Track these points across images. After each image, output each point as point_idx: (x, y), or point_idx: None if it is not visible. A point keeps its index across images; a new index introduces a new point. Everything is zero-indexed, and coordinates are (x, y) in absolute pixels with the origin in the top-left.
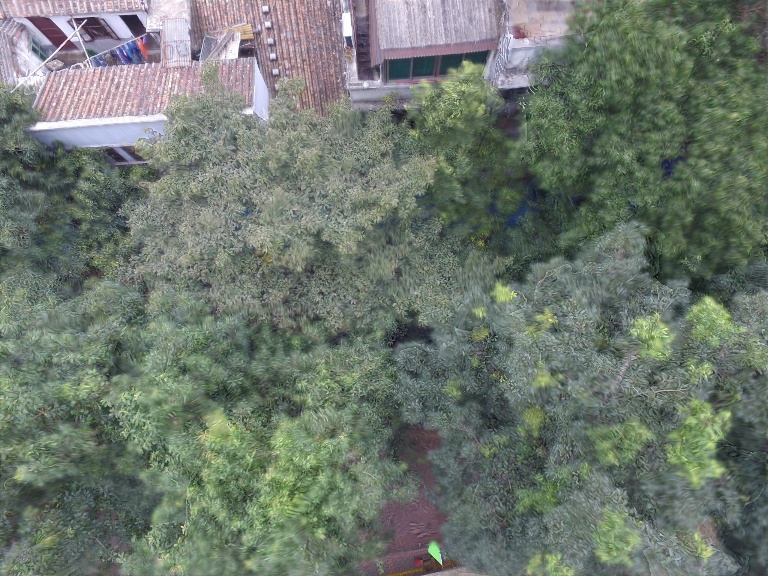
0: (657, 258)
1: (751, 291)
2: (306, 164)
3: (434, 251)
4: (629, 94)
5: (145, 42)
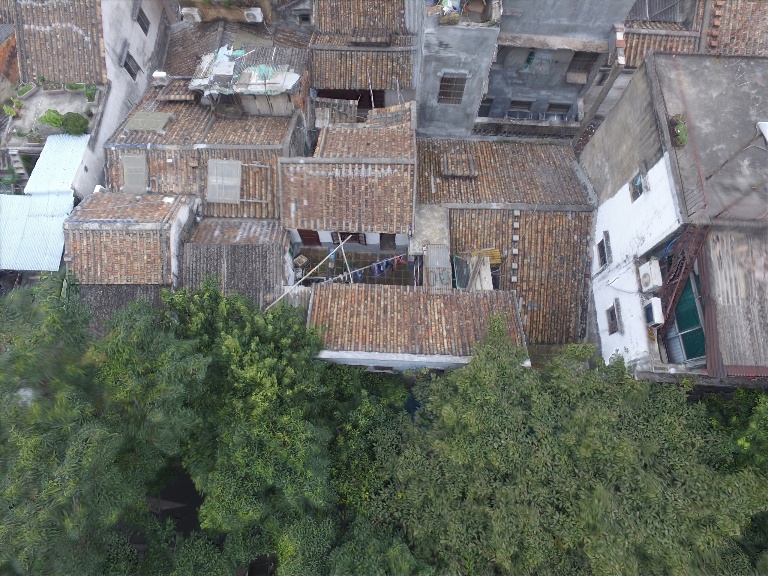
0: None
1: None
2: (624, 459)
3: None
4: None
5: None
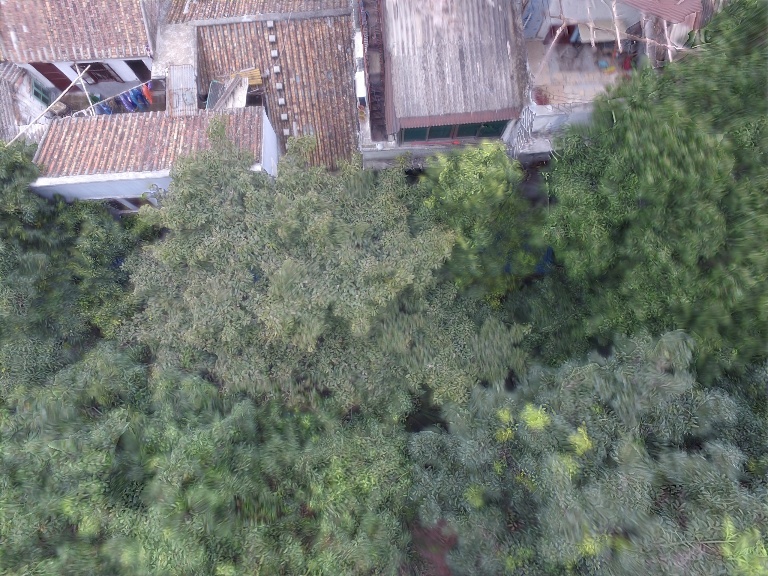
0: None
1: None
2: (317, 233)
3: (448, 315)
4: (665, 186)
5: (150, 83)
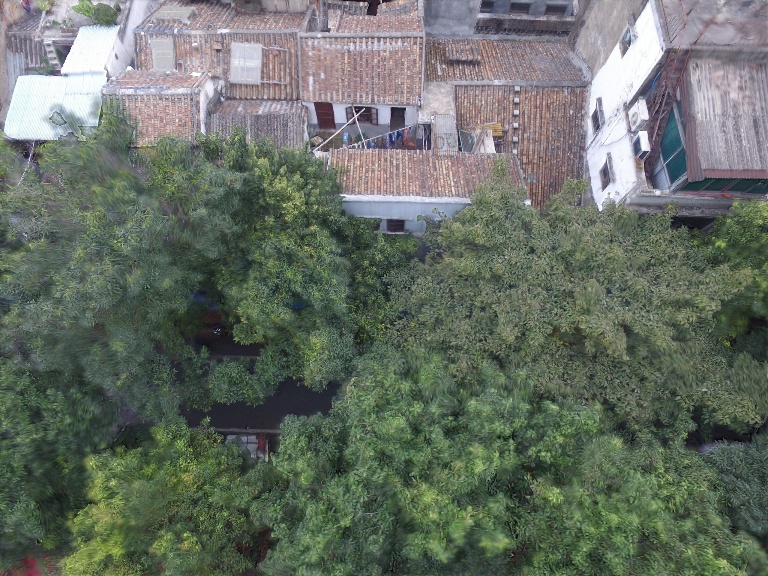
0: None
1: None
2: (614, 259)
3: None
4: None
5: None
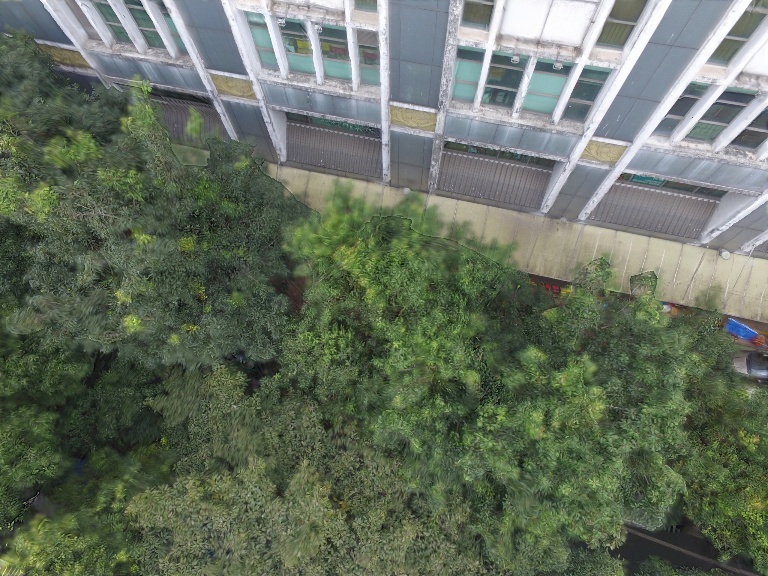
0: (26, 306)
1: None
2: None
3: None
4: None
5: None
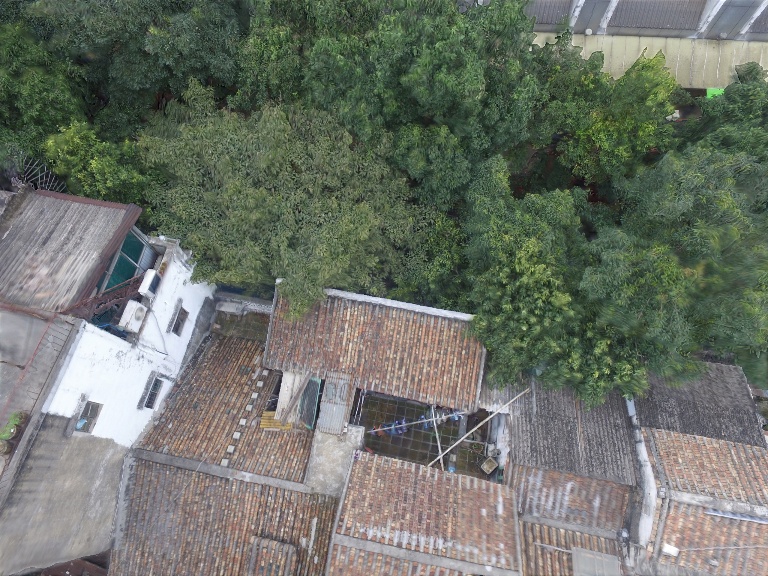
0: None
1: (4, 22)
2: None
3: None
4: None
5: None
